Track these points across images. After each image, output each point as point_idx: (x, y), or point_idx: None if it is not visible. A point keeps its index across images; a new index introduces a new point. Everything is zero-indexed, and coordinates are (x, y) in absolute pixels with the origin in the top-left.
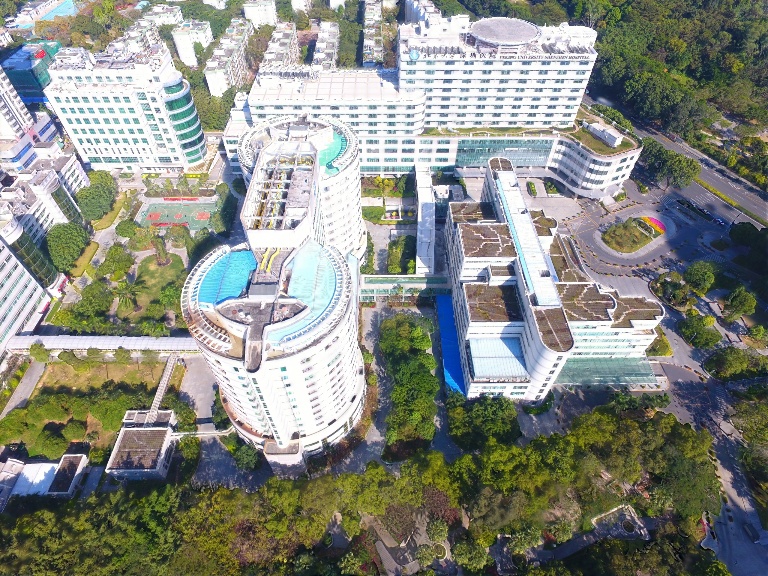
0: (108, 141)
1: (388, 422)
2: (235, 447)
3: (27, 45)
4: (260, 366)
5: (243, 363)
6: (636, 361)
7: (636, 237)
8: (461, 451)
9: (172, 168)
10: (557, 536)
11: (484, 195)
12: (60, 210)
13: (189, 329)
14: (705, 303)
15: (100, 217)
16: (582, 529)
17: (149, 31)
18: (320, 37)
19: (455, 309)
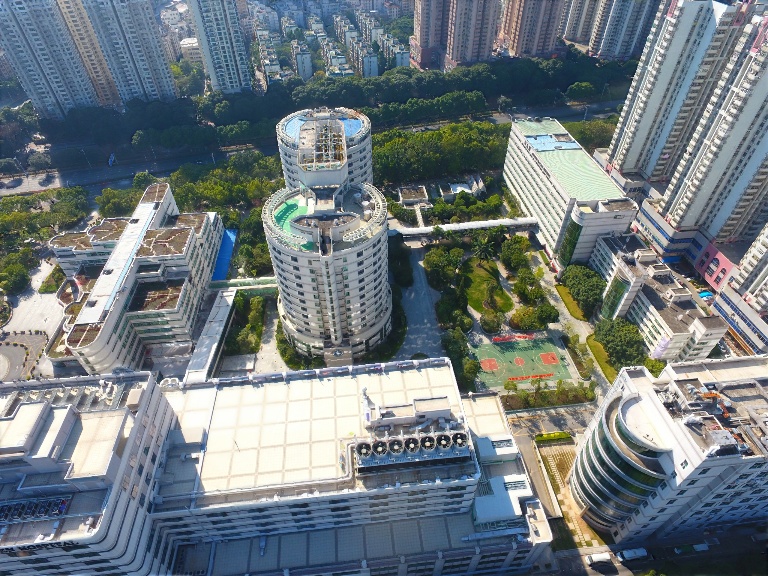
0: None
1: None
2: None
3: None
4: None
5: None
6: None
7: None
8: None
9: None
10: None
11: None
12: None
13: None
14: None
15: None
16: None
17: None
18: None
19: None
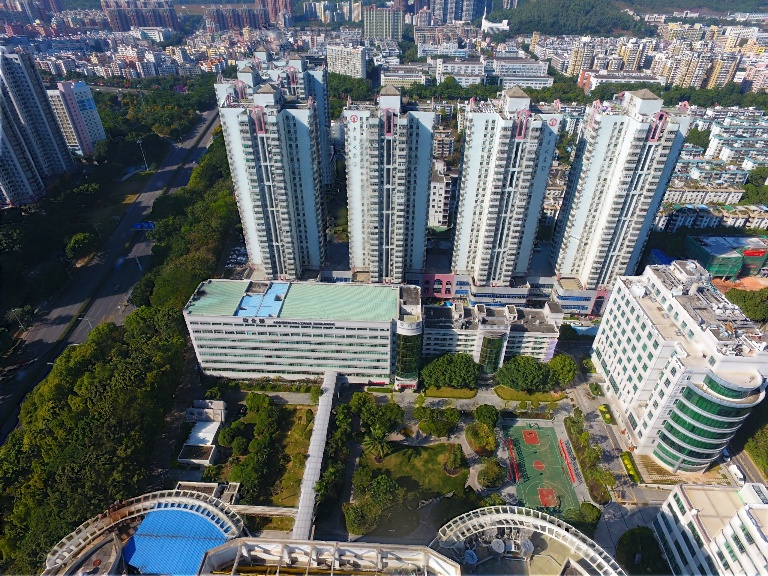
0: (616, 354)
1: None
2: None
3: (763, 239)
4: None
5: None
6: None
7: None
8: None
9: None
10: None
11: None
12: (480, 351)
13: None
14: None
15: None
16: None
17: None
18: None
19: None
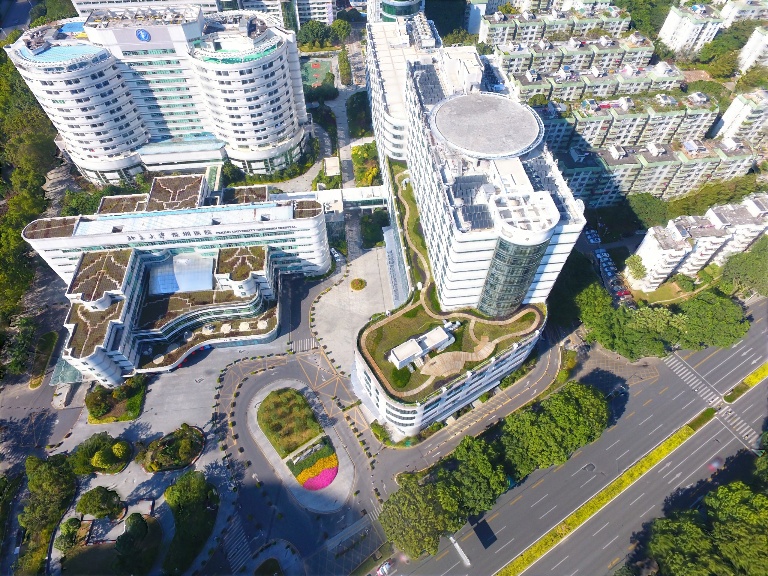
0: None
1: None
2: None
3: None
4: (7, 48)
5: None
6: None
7: (287, 433)
8: None
9: None
10: None
11: None
12: (282, 16)
13: None
14: (154, 496)
15: None
16: None
17: None
18: None
19: None
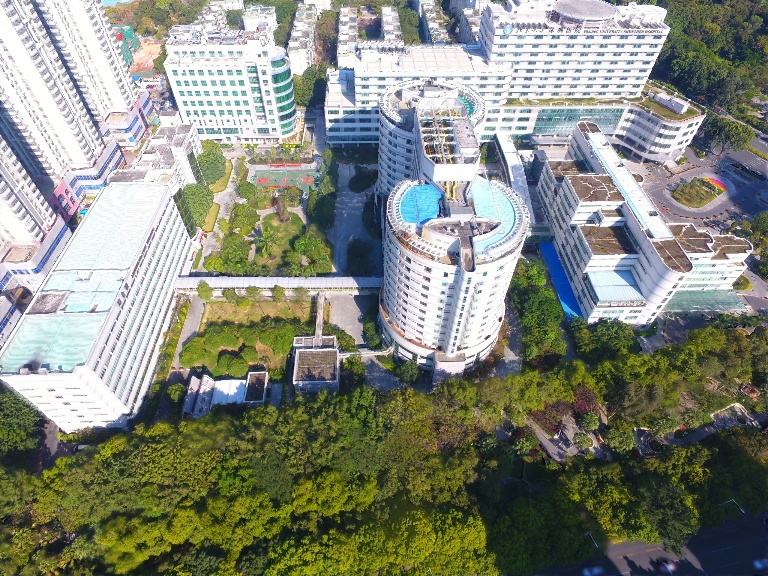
0: (214, 113)
1: (525, 342)
2: (393, 366)
3: None
4: (475, 267)
5: (457, 267)
6: (725, 292)
7: (702, 194)
8: (588, 366)
9: (268, 139)
10: (691, 423)
11: (571, 156)
12: (192, 171)
13: (405, 242)
14: None
15: (214, 182)
16: (704, 422)
17: (220, 15)
18: (384, 21)
19: (561, 252)
